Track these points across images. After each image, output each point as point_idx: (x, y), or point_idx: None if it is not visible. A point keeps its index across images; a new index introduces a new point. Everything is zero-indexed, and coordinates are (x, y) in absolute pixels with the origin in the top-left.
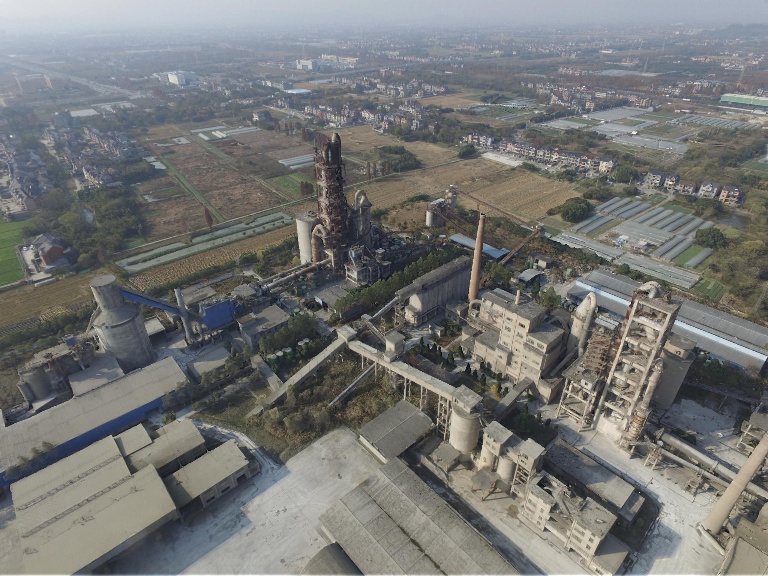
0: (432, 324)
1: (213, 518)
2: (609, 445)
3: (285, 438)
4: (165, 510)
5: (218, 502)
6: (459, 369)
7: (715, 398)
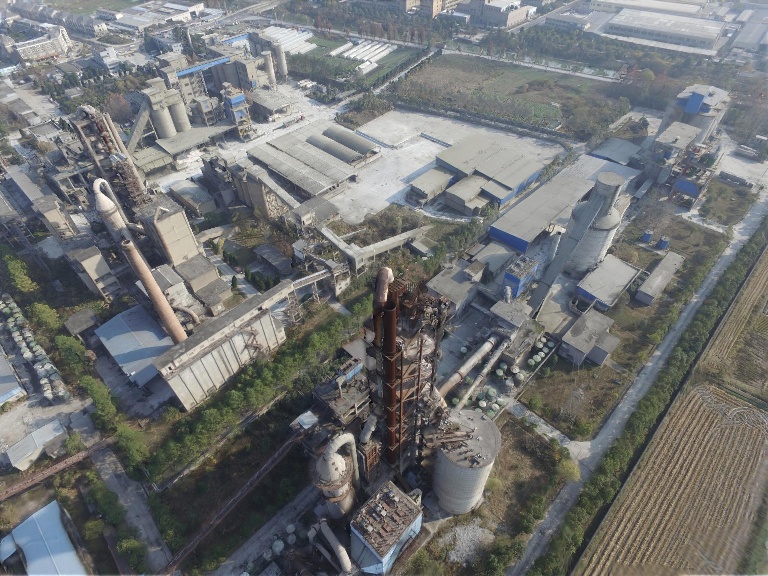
0: None
1: None
2: None
3: None
4: (440, 155)
5: None
6: (243, 275)
7: (26, 259)
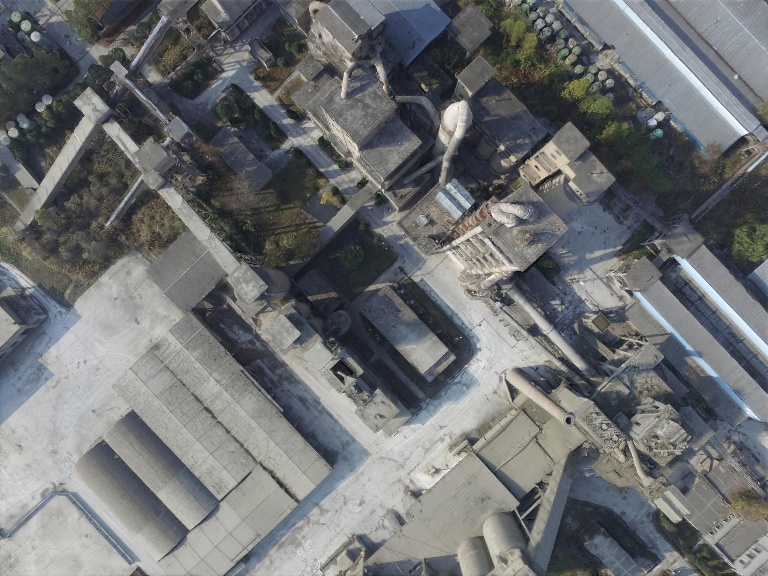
0: (252, 44)
1: (14, 372)
2: None
3: (64, 272)
4: None
5: (13, 354)
6: (290, 143)
7: None
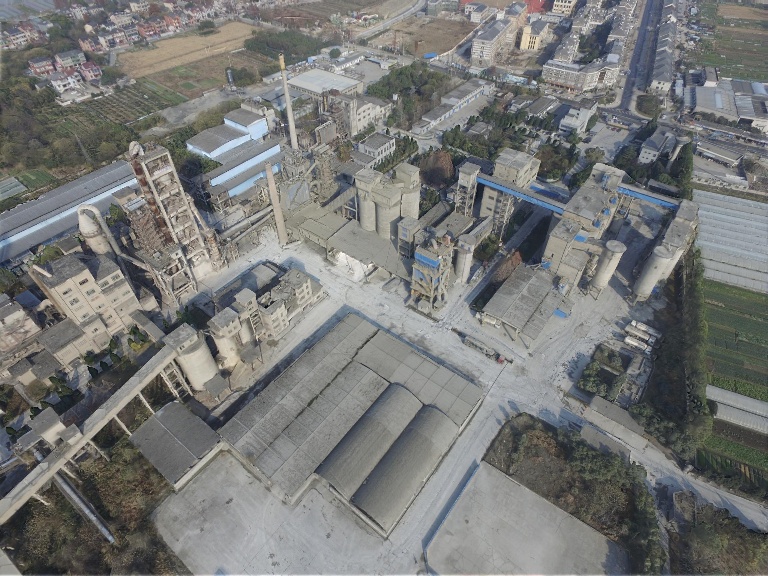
0: None
1: None
2: (214, 277)
3: None
4: None
5: None
6: (83, 387)
7: None
